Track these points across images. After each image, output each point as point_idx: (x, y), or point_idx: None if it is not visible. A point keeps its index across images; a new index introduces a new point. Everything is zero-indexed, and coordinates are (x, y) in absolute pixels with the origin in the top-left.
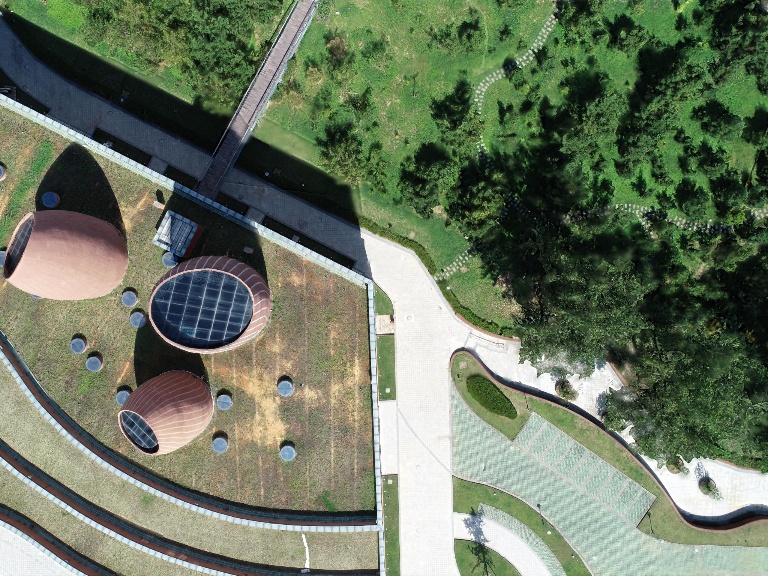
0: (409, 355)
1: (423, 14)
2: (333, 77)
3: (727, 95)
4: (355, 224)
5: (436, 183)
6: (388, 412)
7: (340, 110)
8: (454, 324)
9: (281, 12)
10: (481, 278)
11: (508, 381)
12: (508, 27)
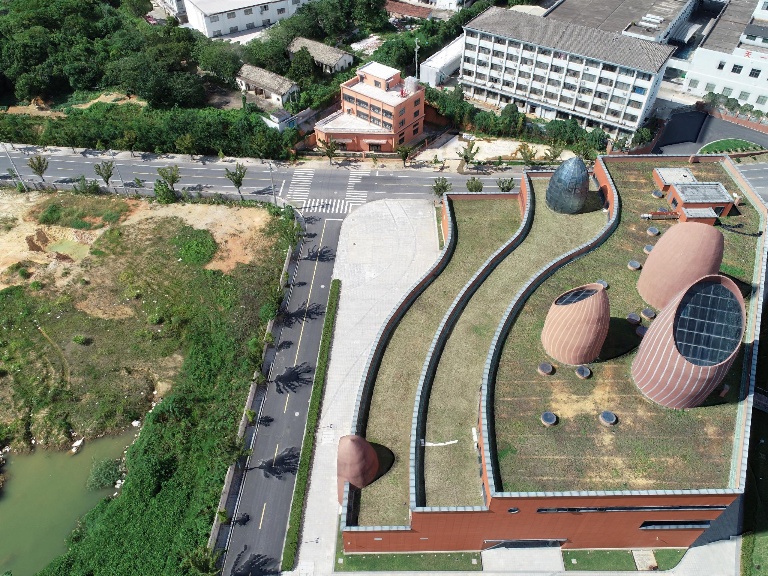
0: None
1: None
2: None
3: None
4: (743, 529)
5: None
6: (550, 561)
7: None
8: None
9: None
10: None
11: None
12: None
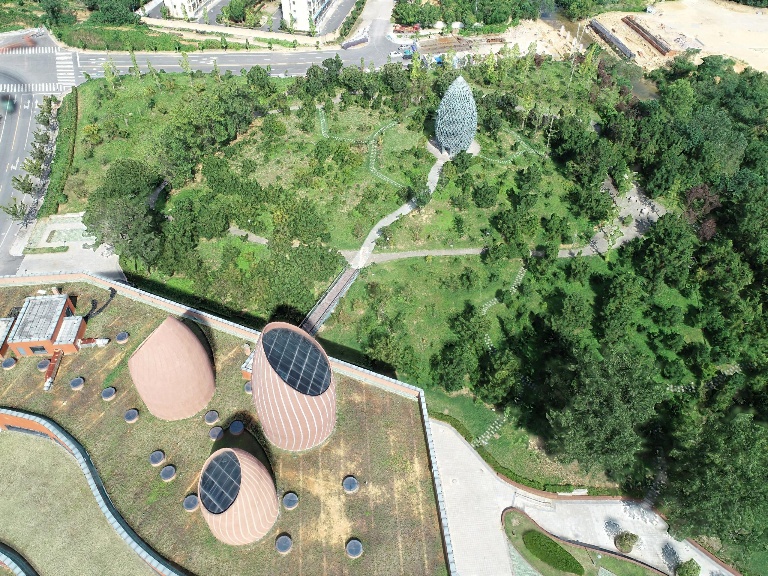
0: (460, 516)
1: (433, 272)
2: (372, 309)
3: (663, 302)
4: None
5: (461, 358)
6: None
7: (378, 328)
8: (498, 484)
9: (334, 276)
10: (514, 443)
11: (565, 540)
12: (494, 274)
